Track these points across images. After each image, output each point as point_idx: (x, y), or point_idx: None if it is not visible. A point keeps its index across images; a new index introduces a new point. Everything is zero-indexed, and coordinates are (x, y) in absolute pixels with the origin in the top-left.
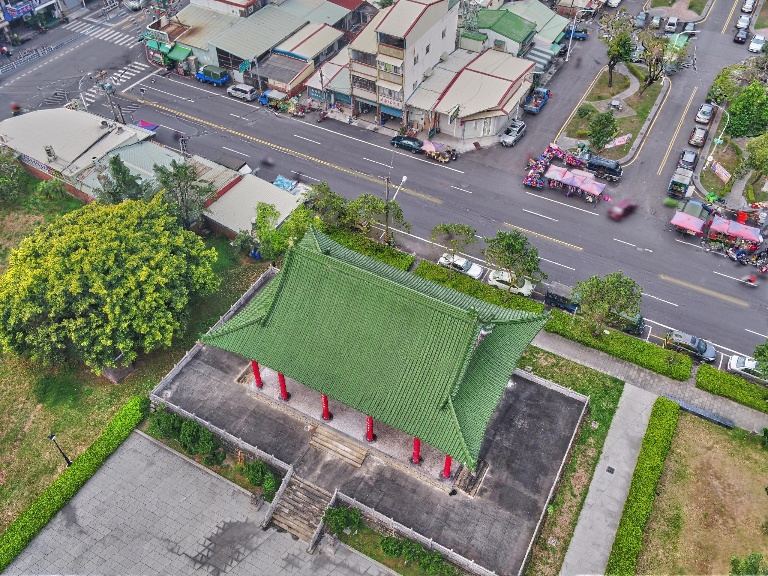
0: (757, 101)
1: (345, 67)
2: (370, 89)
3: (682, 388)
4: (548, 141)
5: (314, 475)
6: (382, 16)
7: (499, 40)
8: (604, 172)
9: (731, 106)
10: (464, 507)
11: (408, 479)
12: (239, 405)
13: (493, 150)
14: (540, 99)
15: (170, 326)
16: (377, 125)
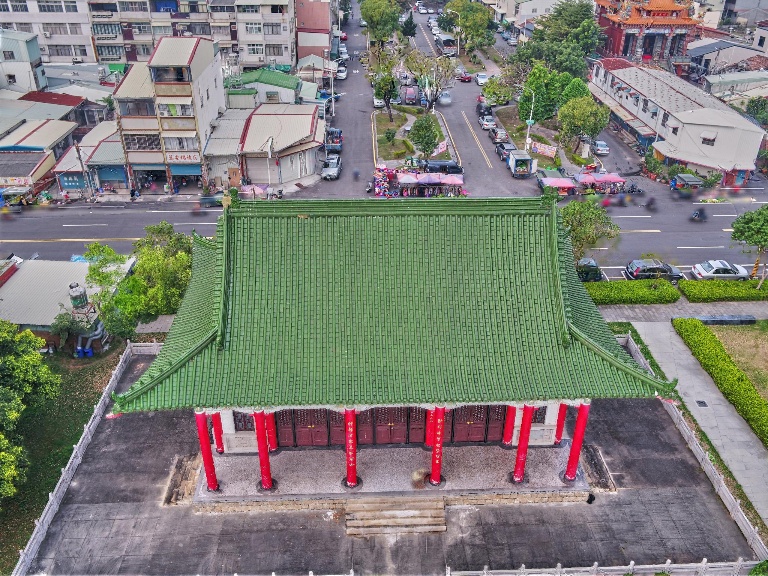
0: (544, 81)
1: (103, 142)
2: (153, 147)
3: (681, 308)
4: (369, 168)
5: (389, 574)
6: (140, 67)
7: (271, 91)
8: (446, 173)
9: (524, 92)
10: (618, 508)
11: (522, 511)
12: (192, 535)
13: (320, 186)
14: (336, 139)
15: (6, 454)
16: (170, 195)
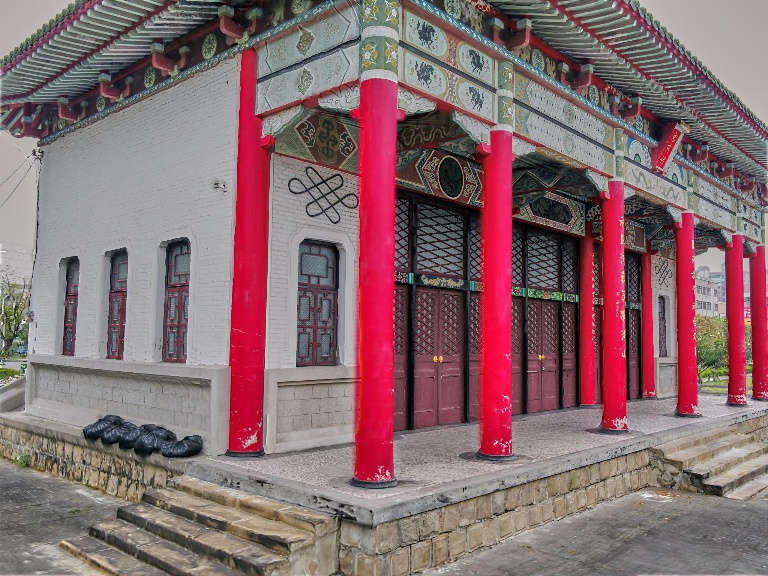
0: None
1: None
2: None
3: None
4: None
5: None
6: None
7: None
8: None
9: None
10: None
11: None
12: None
13: None
14: None
15: None
16: None
